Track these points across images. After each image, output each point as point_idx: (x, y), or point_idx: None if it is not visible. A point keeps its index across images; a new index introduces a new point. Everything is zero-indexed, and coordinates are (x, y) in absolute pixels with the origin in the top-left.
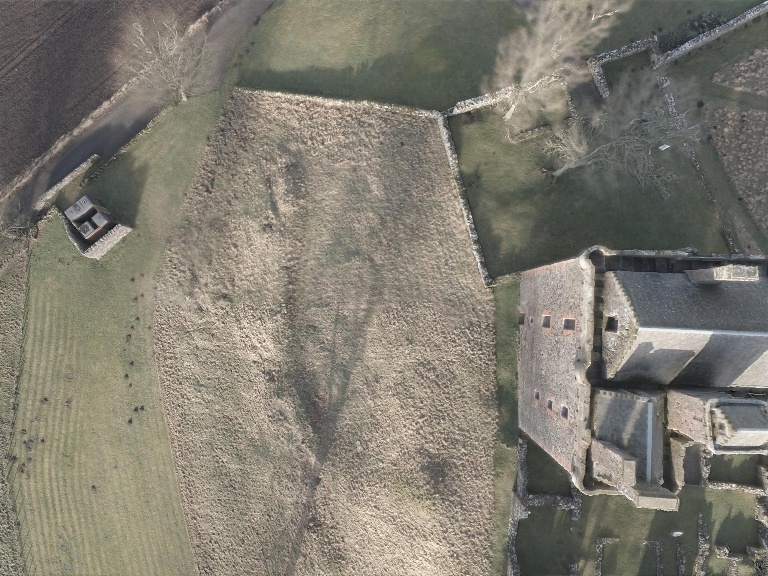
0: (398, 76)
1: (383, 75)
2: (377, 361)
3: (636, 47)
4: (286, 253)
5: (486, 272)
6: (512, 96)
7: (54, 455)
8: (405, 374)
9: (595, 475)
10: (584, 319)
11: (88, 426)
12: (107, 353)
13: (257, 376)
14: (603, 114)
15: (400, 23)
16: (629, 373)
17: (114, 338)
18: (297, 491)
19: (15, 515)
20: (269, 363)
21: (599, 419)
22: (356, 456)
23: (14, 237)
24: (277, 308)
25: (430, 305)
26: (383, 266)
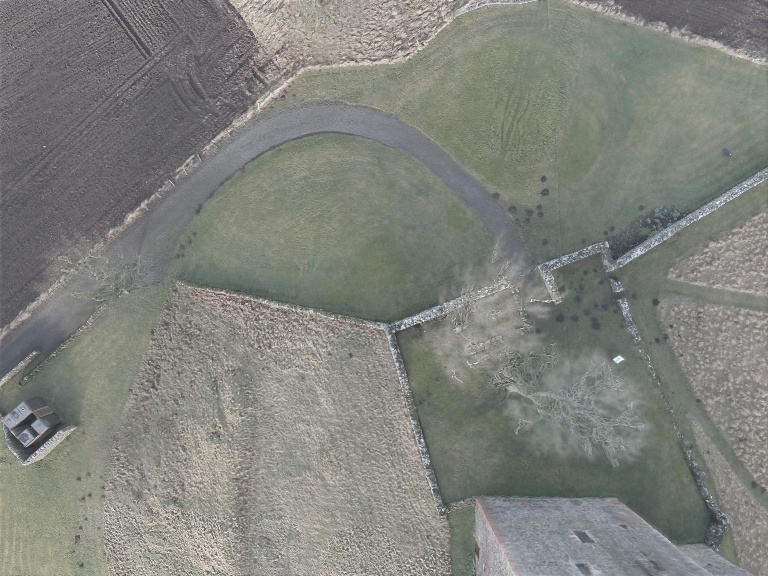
0: (345, 280)
1: (330, 278)
2: None
3: (587, 254)
4: (235, 464)
5: (439, 500)
6: (462, 308)
7: None
8: None
9: None
10: None
11: None
12: (55, 555)
13: None
14: (553, 346)
15: (346, 222)
16: None
17: (62, 539)
18: None
19: None
20: None
21: None
22: None
23: None
24: (228, 522)
25: (384, 531)
26: (334, 487)
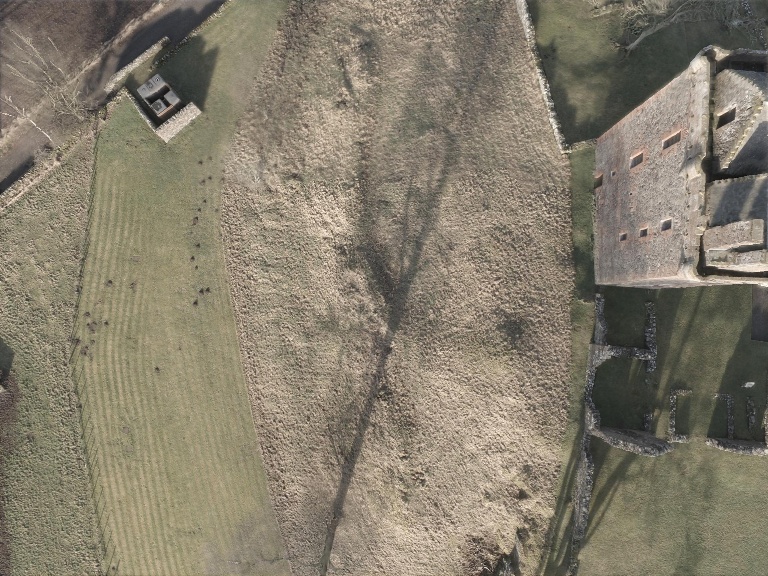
0: None
1: None
2: (452, 229)
3: None
4: (360, 128)
5: (563, 137)
6: None
7: (118, 337)
8: (481, 239)
9: (708, 261)
10: (697, 117)
11: (153, 308)
12: (173, 235)
13: (327, 252)
14: None
15: None
16: (742, 164)
17: (181, 220)
18: (367, 362)
19: (77, 397)
20: (340, 238)
21: (713, 208)
22: (429, 323)
23: (83, 118)
24: (350, 182)
25: (506, 172)
26: (459, 136)
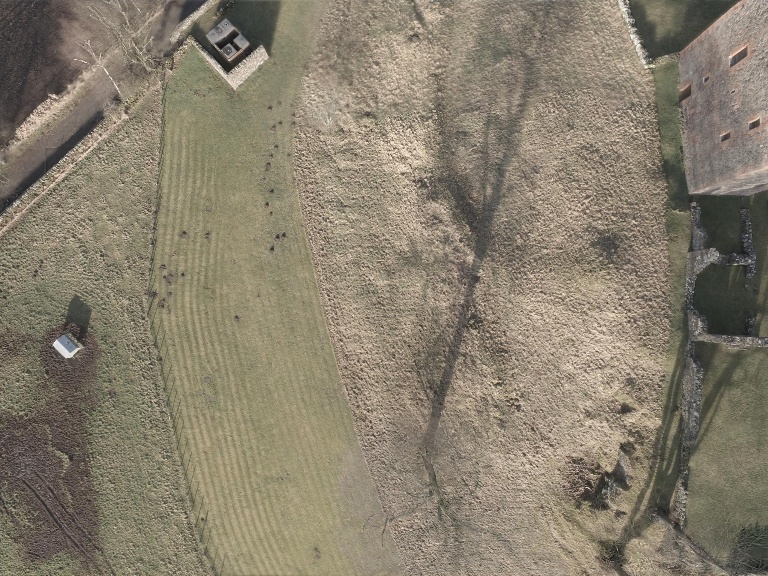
0: None
1: None
2: (536, 152)
3: None
4: (435, 60)
5: (646, 52)
6: None
7: (195, 288)
8: (567, 160)
9: None
10: None
11: (229, 257)
12: (246, 183)
13: (407, 187)
14: None
15: None
16: None
17: (253, 167)
18: (454, 293)
19: (157, 351)
20: (420, 171)
21: None
22: (516, 249)
23: (150, 69)
24: (428, 114)
25: (589, 91)
26: (539, 59)
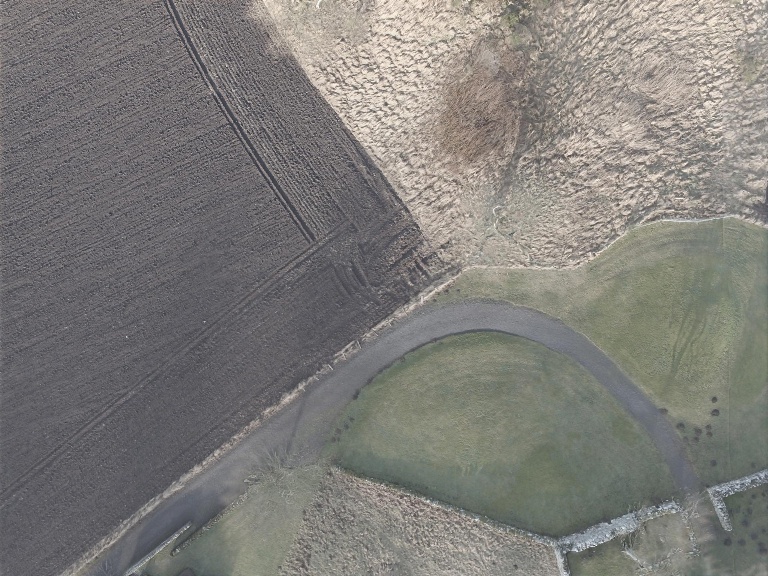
0: (510, 487)
1: (493, 483)
2: None
3: (761, 483)
4: None
5: None
6: (633, 531)
7: None
8: None
9: None
10: None
11: None
12: None
13: None
14: None
15: (511, 427)
16: None
17: None
18: None
19: None
20: None
21: None
22: None
23: None
24: None
25: None
26: None
